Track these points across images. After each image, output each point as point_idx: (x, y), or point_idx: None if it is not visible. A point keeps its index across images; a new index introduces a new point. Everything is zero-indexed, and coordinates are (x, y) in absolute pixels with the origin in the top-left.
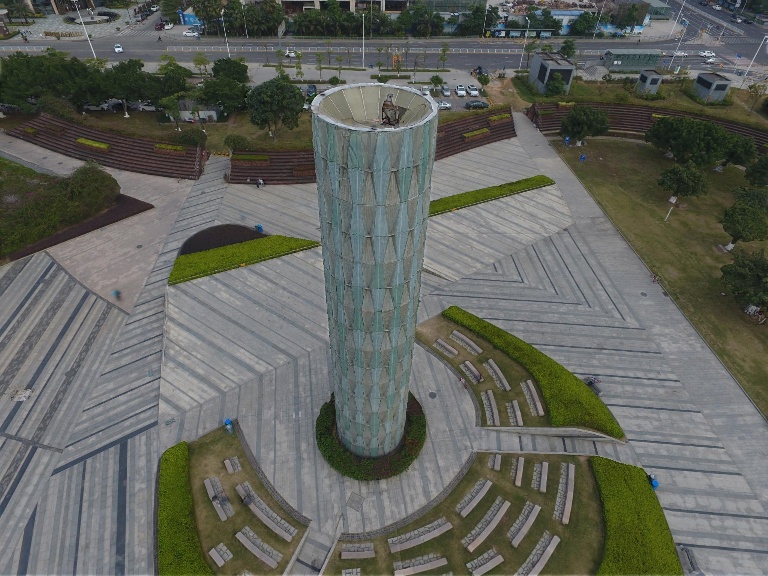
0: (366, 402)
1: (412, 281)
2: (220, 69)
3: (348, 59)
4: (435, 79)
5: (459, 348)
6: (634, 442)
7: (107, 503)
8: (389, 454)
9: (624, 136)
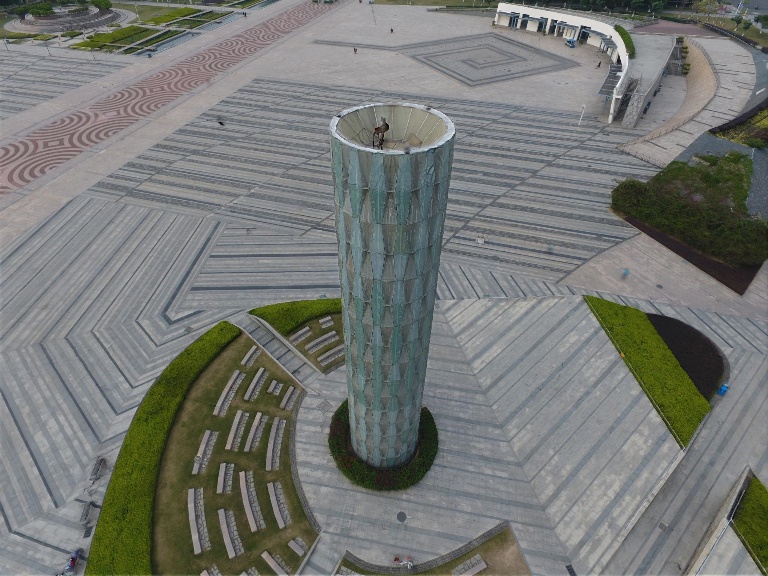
0: None
1: None
2: None
3: None
4: None
5: None
6: None
7: None
8: None
9: None
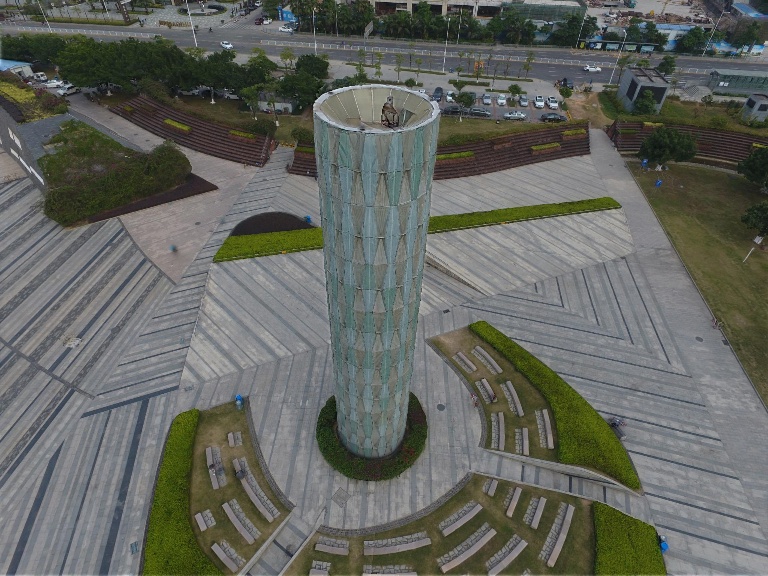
0: (359, 401)
1: (407, 287)
2: (302, 64)
3: (429, 62)
4: (513, 88)
5: (479, 364)
6: (651, 496)
7: (120, 452)
8: (384, 457)
9: (715, 164)
